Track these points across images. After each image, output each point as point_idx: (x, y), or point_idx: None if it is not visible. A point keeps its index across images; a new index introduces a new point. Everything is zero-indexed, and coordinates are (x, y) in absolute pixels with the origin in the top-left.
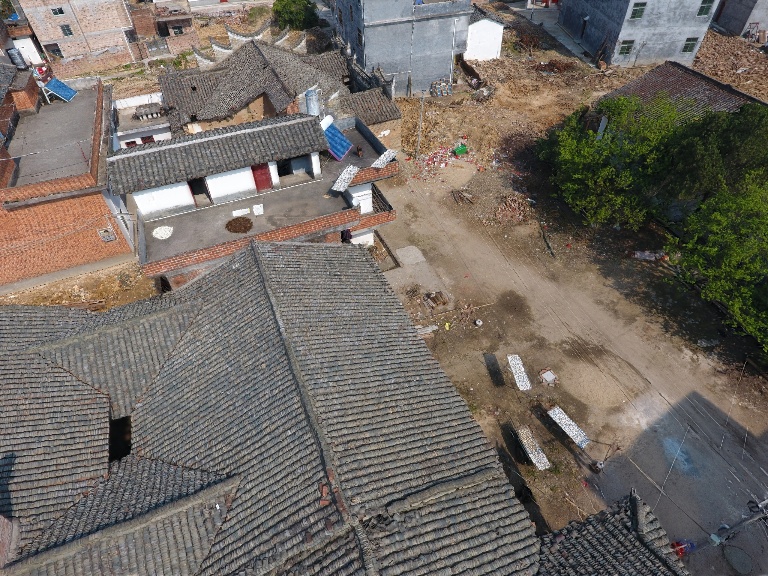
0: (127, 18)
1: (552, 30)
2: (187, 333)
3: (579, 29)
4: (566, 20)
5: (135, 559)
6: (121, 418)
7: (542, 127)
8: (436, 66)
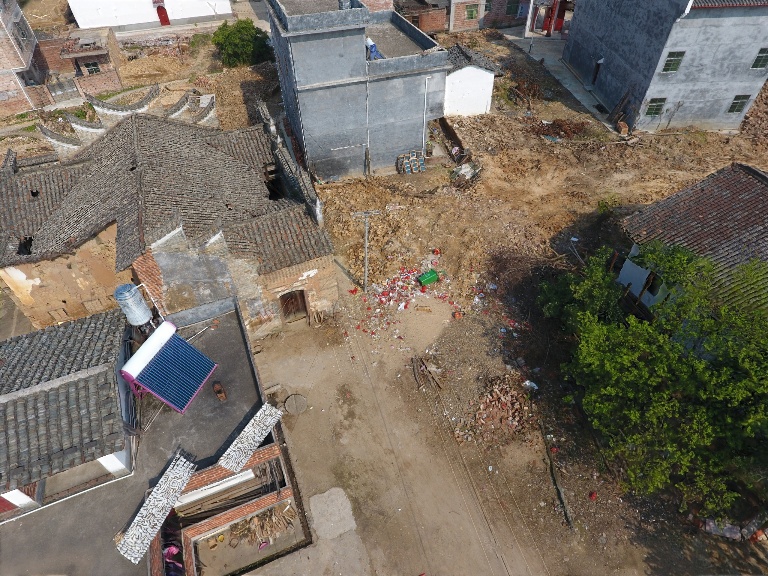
0: (18, 57)
1: (556, 69)
2: None
3: (590, 72)
4: (573, 58)
5: None
6: None
7: (546, 234)
8: (403, 136)
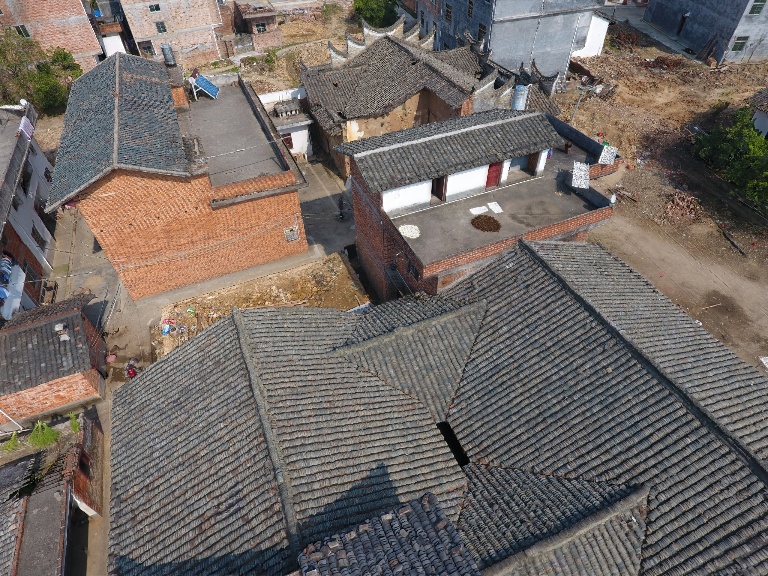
0: (218, 15)
1: (641, 27)
2: (481, 335)
3: (675, 26)
4: (656, 17)
5: (571, 575)
6: (436, 424)
7: (676, 124)
8: (553, 63)
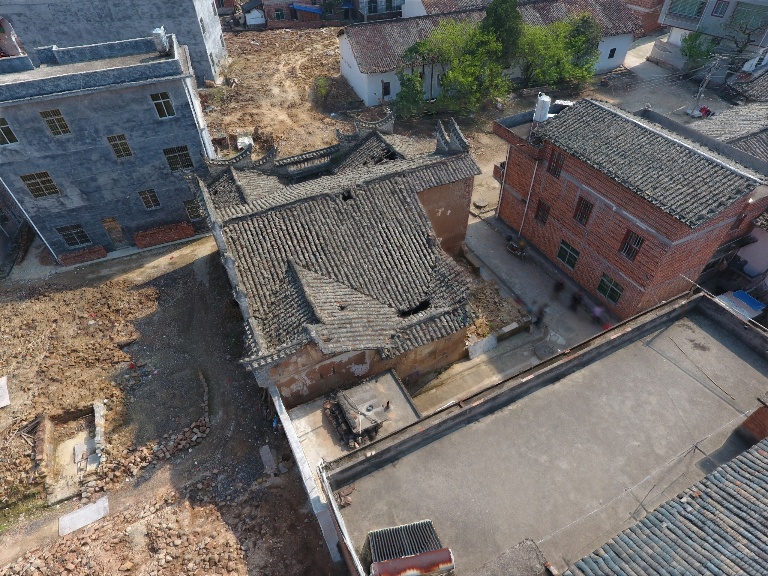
0: None
1: None
2: None
3: None
4: None
5: None
6: None
7: None
8: None
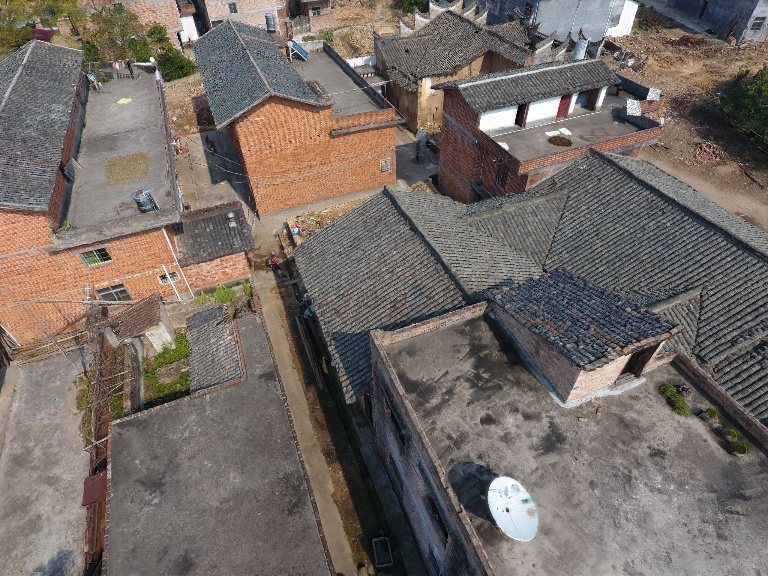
0: None
1: (665, 12)
2: (566, 213)
3: (698, 10)
4: (679, 2)
5: None
6: None
7: (701, 90)
8: None
